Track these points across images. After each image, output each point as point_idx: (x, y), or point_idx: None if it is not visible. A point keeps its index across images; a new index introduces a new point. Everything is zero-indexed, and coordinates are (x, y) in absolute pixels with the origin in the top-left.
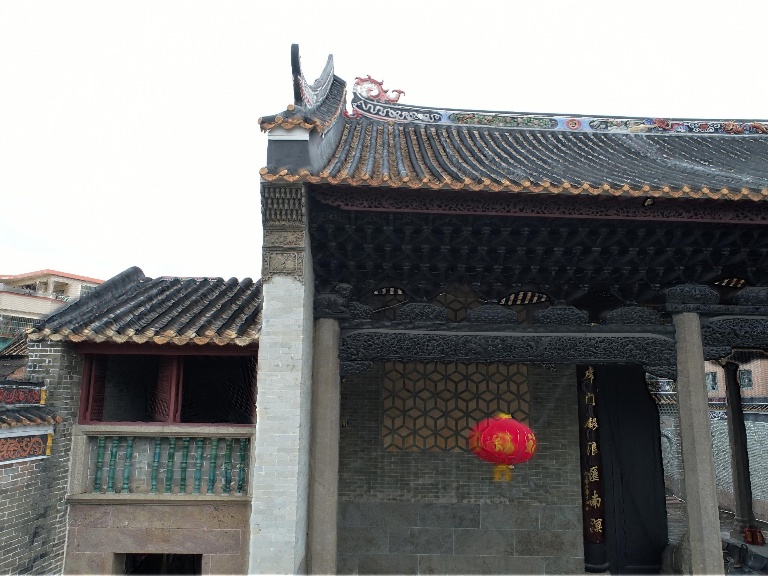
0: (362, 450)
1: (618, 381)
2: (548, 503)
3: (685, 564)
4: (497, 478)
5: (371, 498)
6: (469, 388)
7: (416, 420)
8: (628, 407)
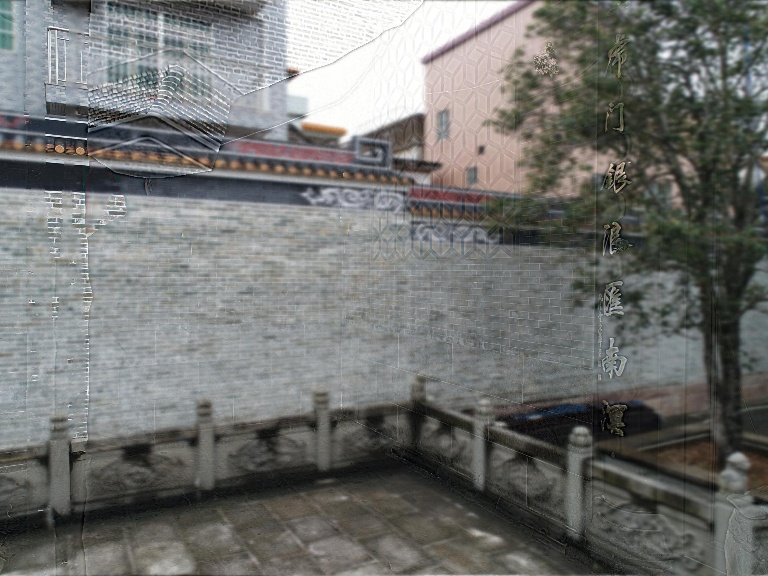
0: (360, 262)
1: (725, 47)
2: (536, 355)
3: (729, 574)
4: (472, 303)
5: (365, 324)
6: (444, 152)
7: (397, 216)
8: (751, 115)
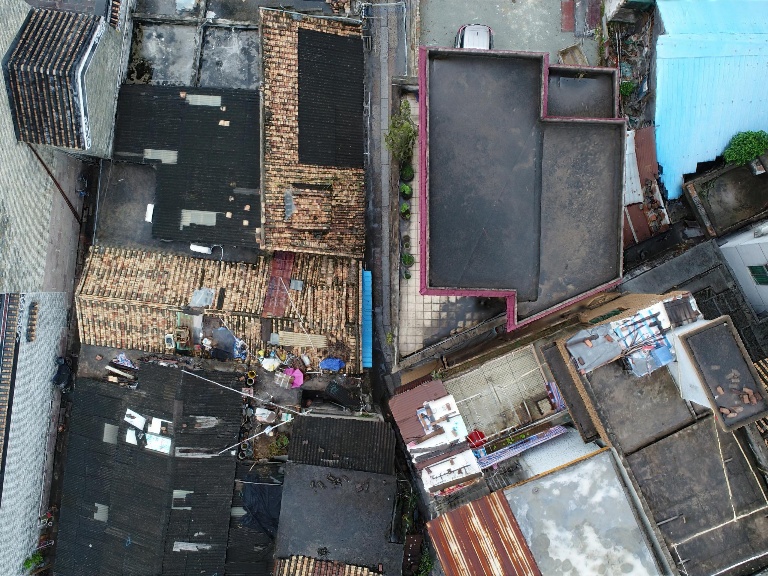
0: None
1: None
2: None
3: None
4: None
5: None
6: None
7: None
8: None
